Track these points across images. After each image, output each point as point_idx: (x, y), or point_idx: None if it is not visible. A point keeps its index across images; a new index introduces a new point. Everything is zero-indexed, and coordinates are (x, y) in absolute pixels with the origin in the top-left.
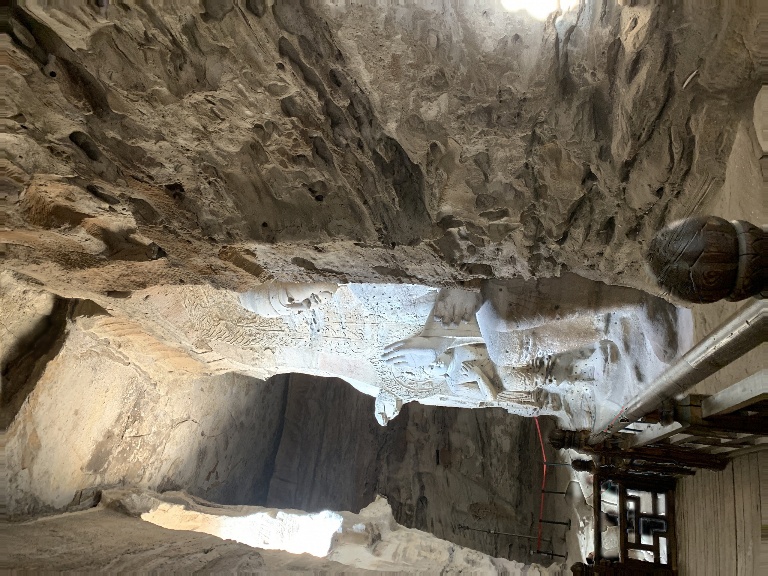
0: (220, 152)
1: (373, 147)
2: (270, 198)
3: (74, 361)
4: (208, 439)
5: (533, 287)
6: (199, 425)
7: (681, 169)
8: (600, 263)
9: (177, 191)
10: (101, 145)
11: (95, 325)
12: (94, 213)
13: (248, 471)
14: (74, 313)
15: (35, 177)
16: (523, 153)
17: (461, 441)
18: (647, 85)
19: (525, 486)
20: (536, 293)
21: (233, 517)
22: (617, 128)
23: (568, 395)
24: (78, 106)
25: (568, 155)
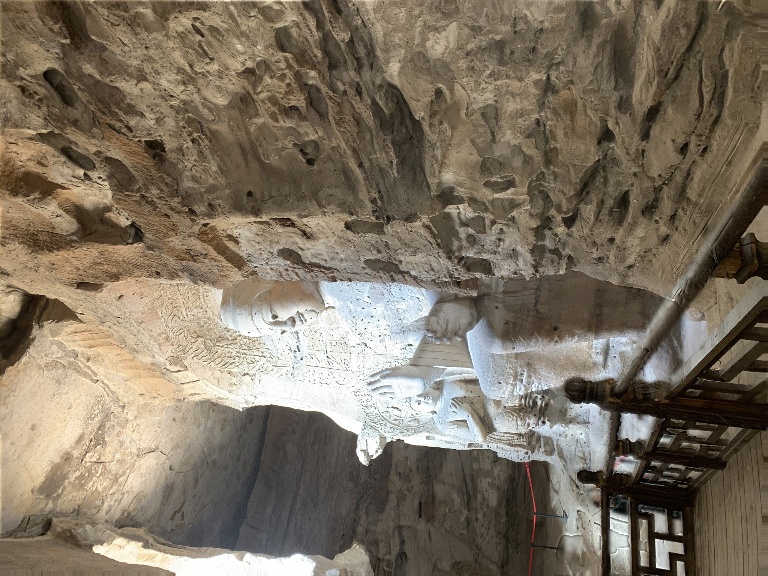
0: (207, 103)
1: (372, 95)
2: (258, 163)
3: (37, 370)
4: (176, 475)
5: (531, 306)
6: (168, 458)
7: (710, 115)
8: (610, 253)
9: (157, 151)
10: (77, 83)
11: (63, 332)
12: (68, 183)
13: (217, 515)
14: (42, 317)
15: (6, 132)
16: (535, 105)
17: (446, 493)
18: (678, 6)
19: (512, 545)
20: (534, 312)
21: (195, 558)
22: (640, 69)
23: (562, 439)
24: (54, 30)
25: (584, 106)
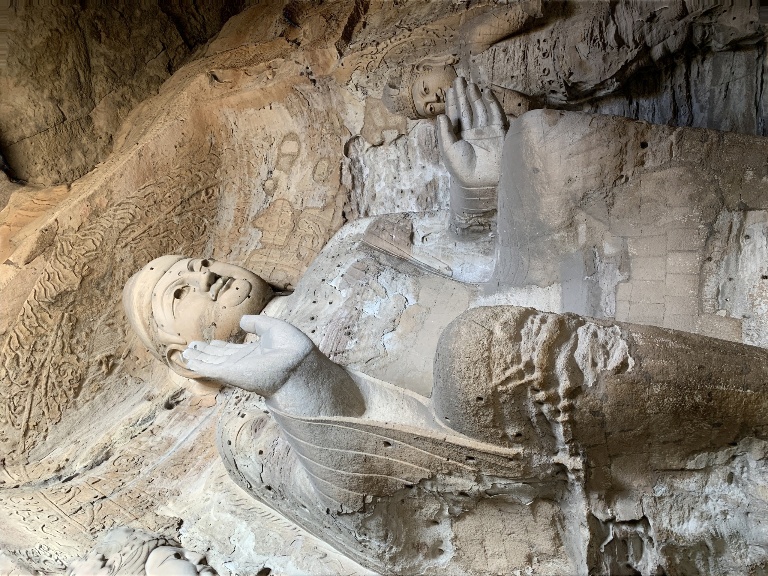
0: None
1: None
2: None
3: None
4: None
5: None
6: None
7: None
8: None
9: None
10: None
11: (34, 193)
12: None
13: None
14: None
15: (320, 3)
16: None
17: None
18: None
19: None
20: None
21: None
22: None
23: None
24: None
25: None
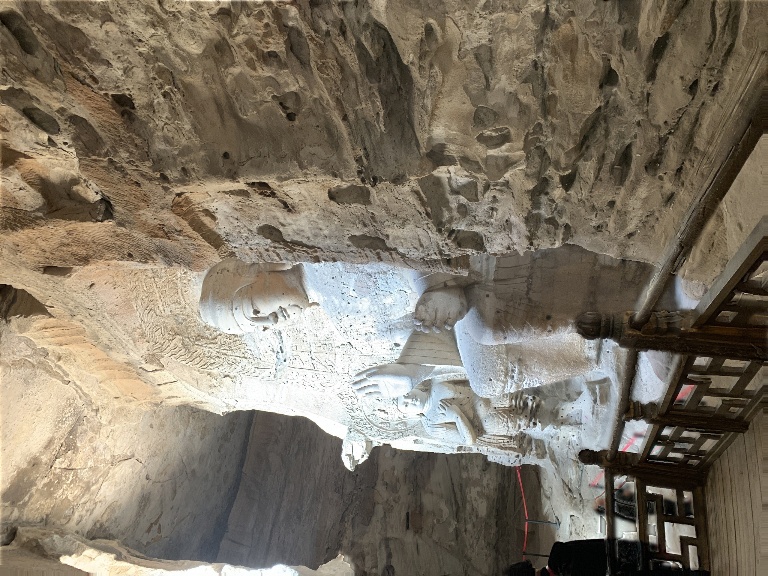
0: (179, 51)
1: (357, 35)
2: (234, 120)
3: (3, 368)
4: (153, 484)
5: (523, 294)
6: (144, 466)
7: (724, 43)
8: (610, 219)
9: (126, 108)
10: (36, 25)
11: (32, 328)
12: (31, 152)
13: (196, 528)
14: (9, 312)
15: None
16: (533, 43)
17: (434, 503)
18: None
19: (502, 556)
20: (526, 300)
21: (171, 571)
22: None
23: (553, 441)
24: None
25: (586, 43)
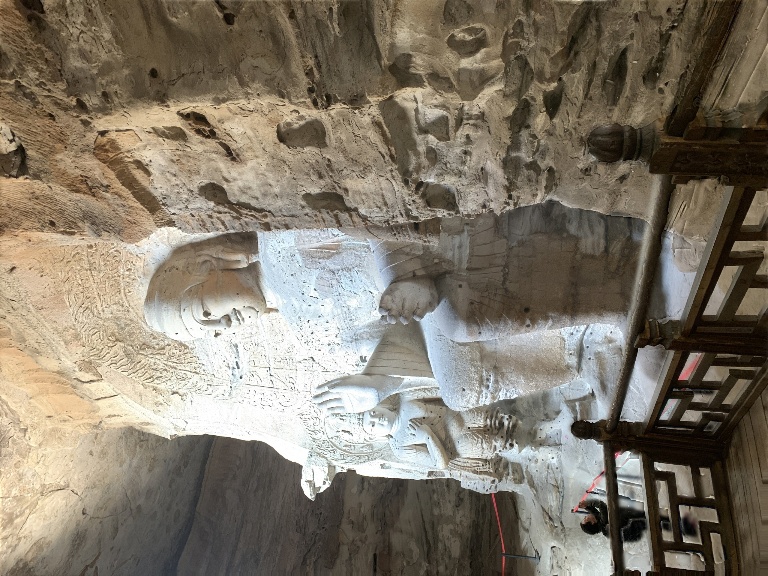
0: None
1: None
2: (163, 28)
3: None
4: (90, 520)
5: (499, 284)
6: (80, 499)
7: None
8: None
9: (34, 11)
10: None
11: None
12: None
13: (140, 573)
14: None
15: None
16: None
17: (403, 543)
18: None
19: None
20: (502, 291)
21: None
22: None
23: (531, 465)
24: None
25: None
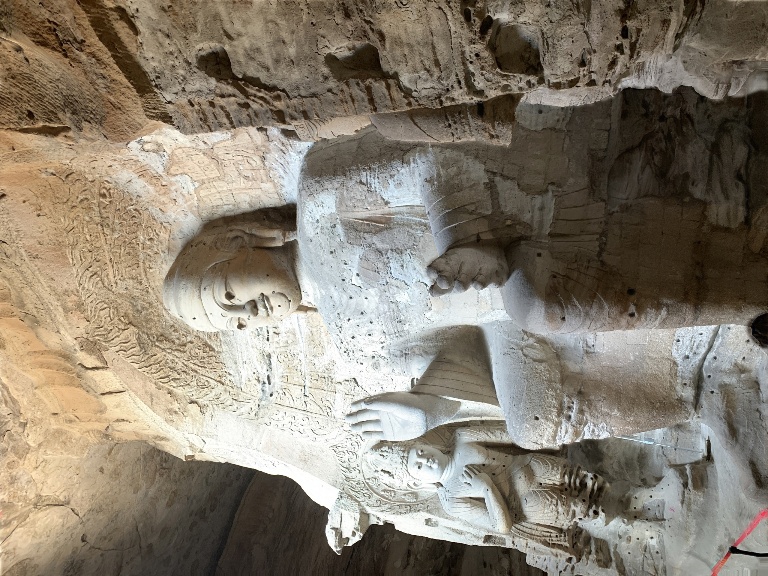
0: None
1: None
2: None
3: None
4: (90, 550)
5: (592, 254)
6: (81, 522)
7: None
8: None
9: None
10: None
11: None
12: None
13: None
14: None
15: None
16: None
17: None
18: None
19: None
20: (597, 263)
21: None
22: None
23: (622, 544)
24: None
25: None
